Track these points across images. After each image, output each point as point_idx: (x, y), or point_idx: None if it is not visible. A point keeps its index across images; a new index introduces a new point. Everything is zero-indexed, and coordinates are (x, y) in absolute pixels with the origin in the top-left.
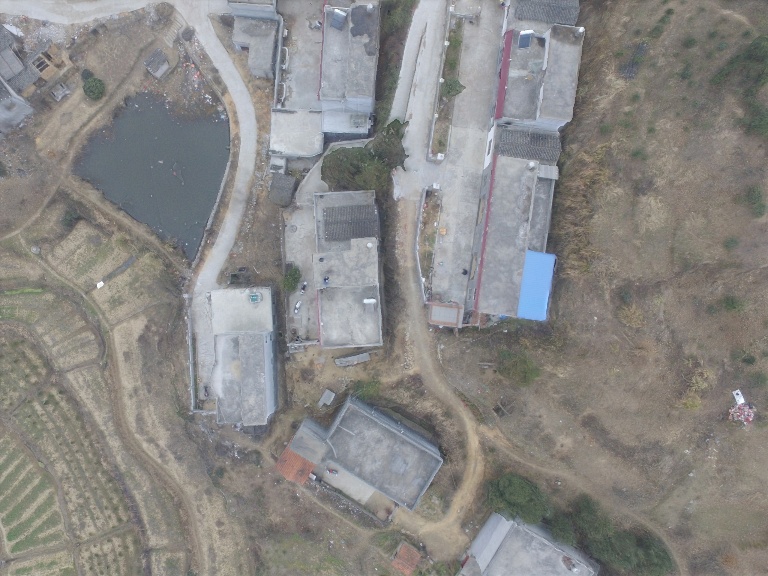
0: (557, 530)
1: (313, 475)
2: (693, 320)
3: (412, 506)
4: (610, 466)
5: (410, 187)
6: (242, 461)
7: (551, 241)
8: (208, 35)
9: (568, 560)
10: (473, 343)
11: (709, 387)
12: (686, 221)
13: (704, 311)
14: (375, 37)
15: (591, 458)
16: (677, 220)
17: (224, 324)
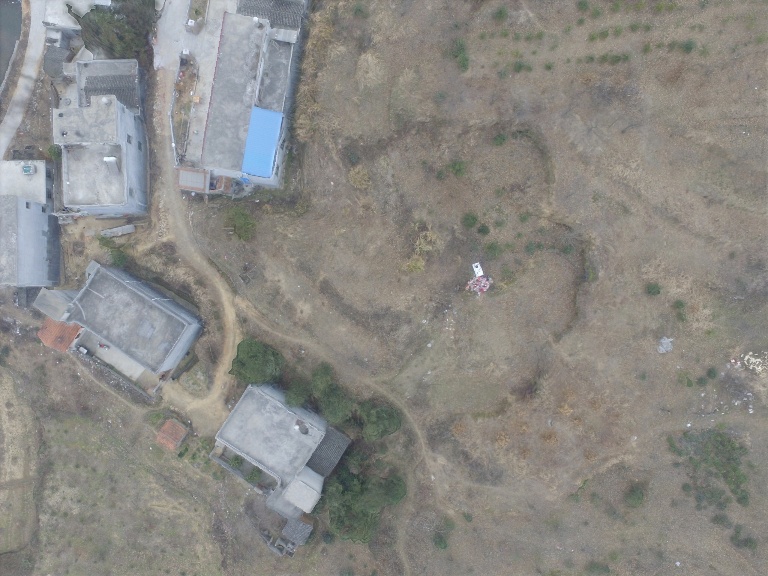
0: (292, 394)
1: (84, 349)
2: (423, 185)
3: None
4: (351, 335)
5: (170, 57)
6: (25, 339)
7: (288, 104)
8: None
9: (302, 424)
10: (220, 209)
11: (436, 252)
12: (400, 77)
13: (435, 177)
14: None
15: (331, 326)
16: (394, 77)
17: None
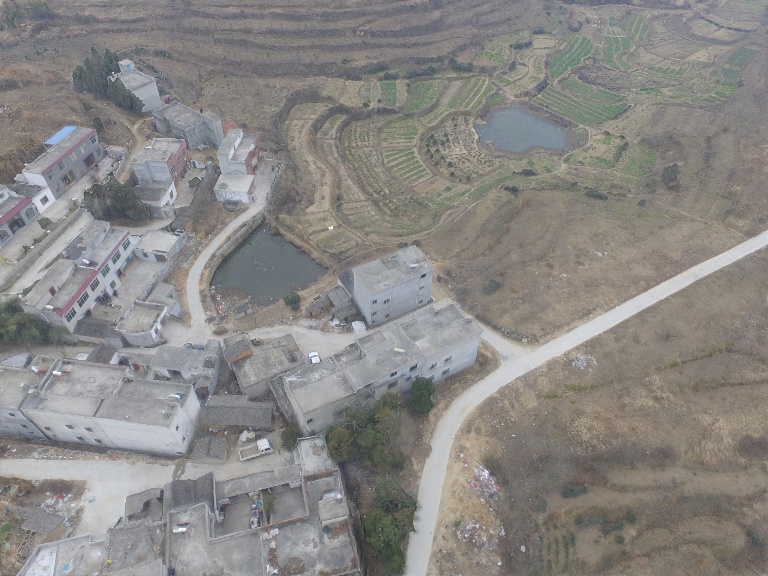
0: None
1: None
2: None
3: (175, 103)
4: None
5: None
6: None
7: None
8: (197, 318)
9: None
10: (110, 140)
11: None
12: None
13: None
14: (73, 245)
15: None
16: None
17: (246, 179)
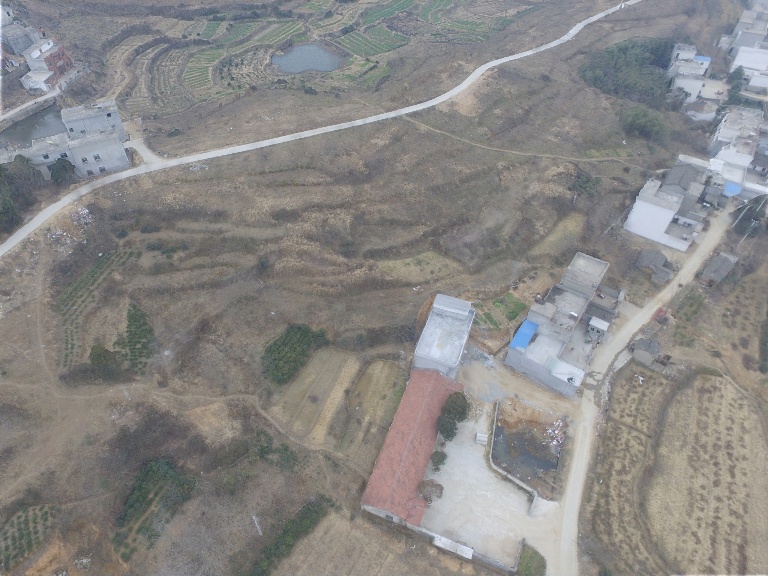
0: None
1: None
2: None
3: (13, 23)
4: None
5: None
6: None
7: None
8: None
9: None
10: None
11: None
12: None
13: None
14: None
15: None
16: None
17: (47, 74)
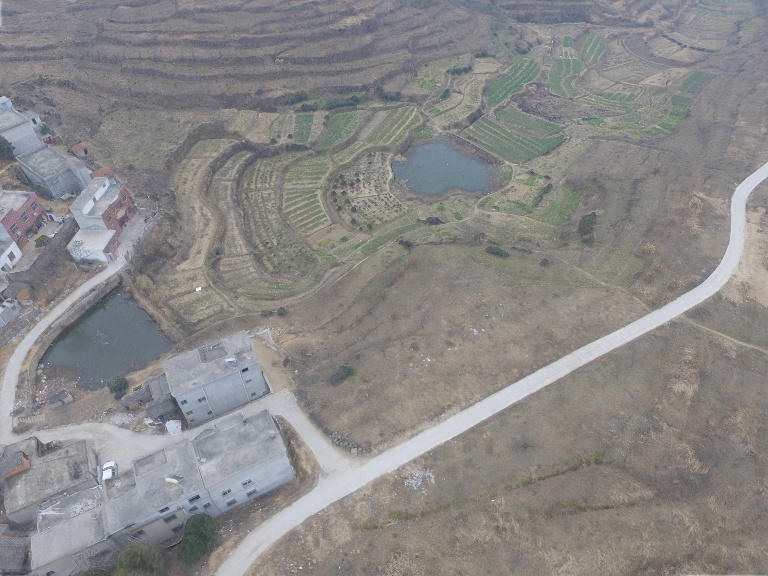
0: None
1: None
2: None
3: (46, 146)
4: None
5: None
6: None
7: None
8: (4, 410)
9: None
10: None
11: None
12: None
13: None
14: None
15: None
16: None
17: (106, 235)
